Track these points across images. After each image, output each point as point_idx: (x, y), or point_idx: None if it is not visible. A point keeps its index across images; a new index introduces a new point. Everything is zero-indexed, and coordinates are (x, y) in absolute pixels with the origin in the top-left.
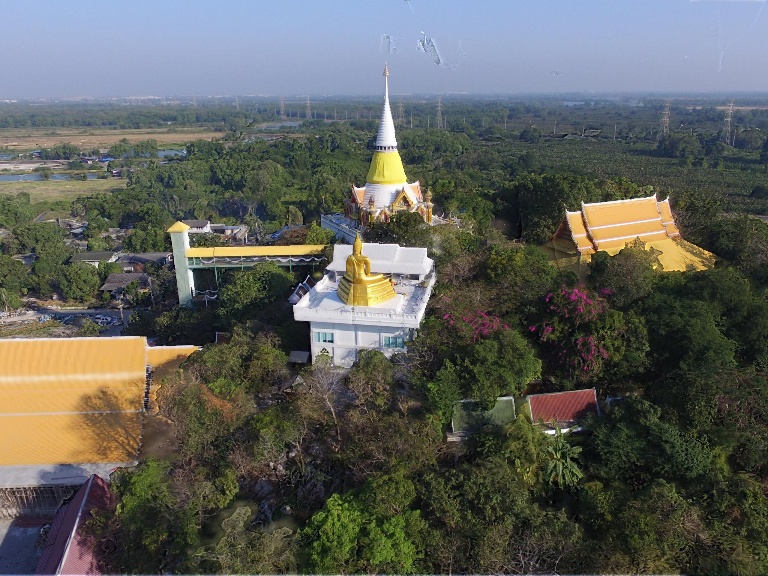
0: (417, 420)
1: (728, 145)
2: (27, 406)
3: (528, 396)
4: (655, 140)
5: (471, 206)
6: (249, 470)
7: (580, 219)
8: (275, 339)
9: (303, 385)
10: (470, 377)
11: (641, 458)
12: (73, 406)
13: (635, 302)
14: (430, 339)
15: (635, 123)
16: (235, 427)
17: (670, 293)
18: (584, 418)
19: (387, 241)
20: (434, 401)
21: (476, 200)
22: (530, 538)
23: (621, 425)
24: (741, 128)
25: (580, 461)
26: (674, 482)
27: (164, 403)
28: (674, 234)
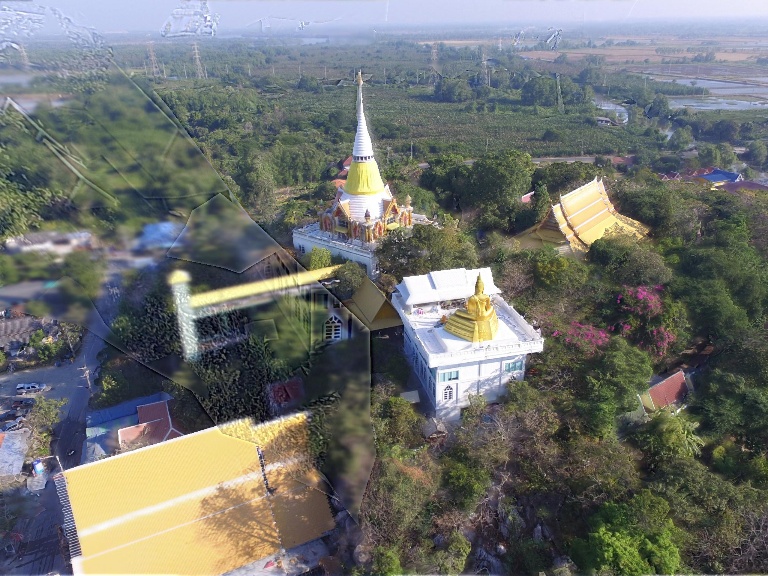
0: (583, 436)
1: (493, 88)
2: (134, 532)
3: (648, 390)
4: (428, 84)
5: (420, 199)
6: (442, 524)
7: (560, 211)
8: (389, 387)
9: (462, 429)
10: (618, 388)
11: (742, 419)
12: (190, 515)
13: (664, 287)
14: (562, 360)
15: (401, 67)
16: (436, 490)
17: (684, 275)
18: (687, 397)
19: (399, 255)
20: (604, 418)
21: (423, 192)
22: (737, 511)
23: (722, 398)
24: (493, 69)
25: (695, 432)
26: (759, 430)
27: (366, 489)
28: (612, 210)
